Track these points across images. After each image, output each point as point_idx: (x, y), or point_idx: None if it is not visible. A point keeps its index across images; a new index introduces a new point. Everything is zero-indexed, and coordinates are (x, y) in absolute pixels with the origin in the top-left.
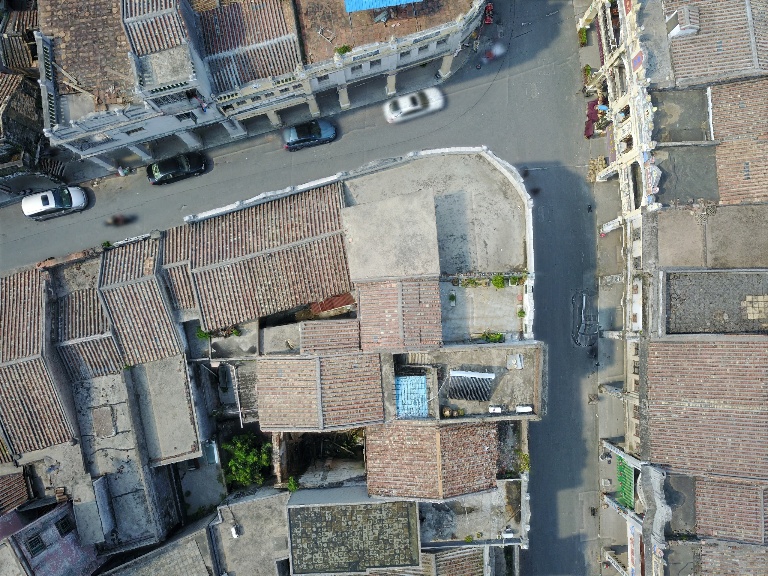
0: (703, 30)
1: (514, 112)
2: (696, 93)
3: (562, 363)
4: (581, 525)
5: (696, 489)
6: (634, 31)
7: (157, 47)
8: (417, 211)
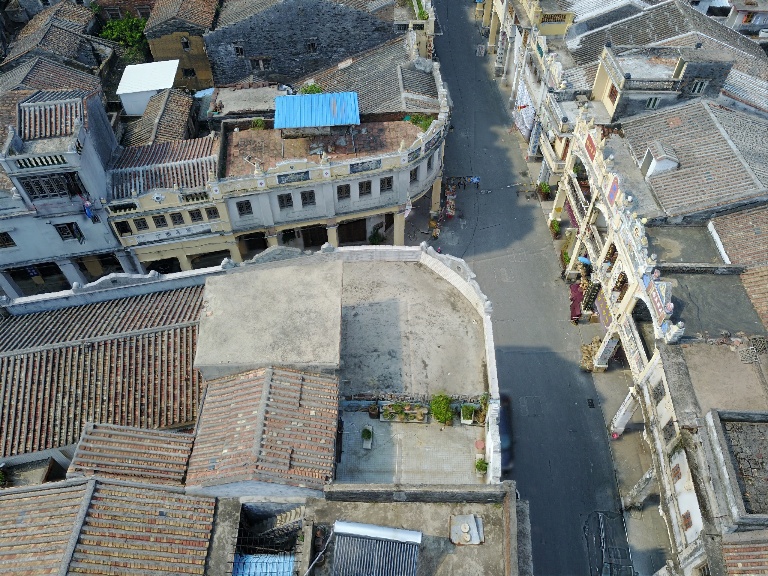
0: (684, 165)
1: None
2: (695, 230)
3: None
4: None
5: None
6: (603, 166)
7: (48, 133)
8: (315, 284)
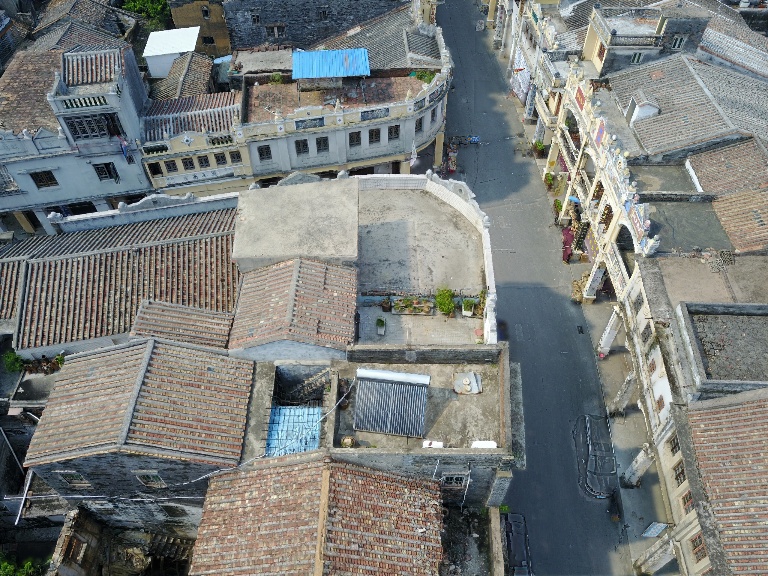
0: (664, 111)
1: None
2: (674, 168)
3: (569, 524)
4: None
5: None
6: (591, 113)
7: (90, 79)
8: (335, 196)
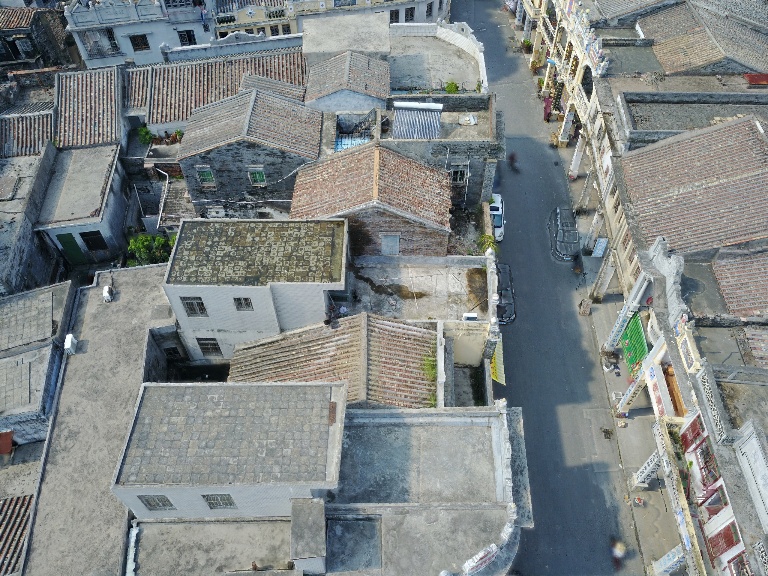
0: None
1: None
2: (627, 31)
3: (543, 276)
4: (592, 450)
5: (715, 274)
6: None
7: None
8: (372, 22)
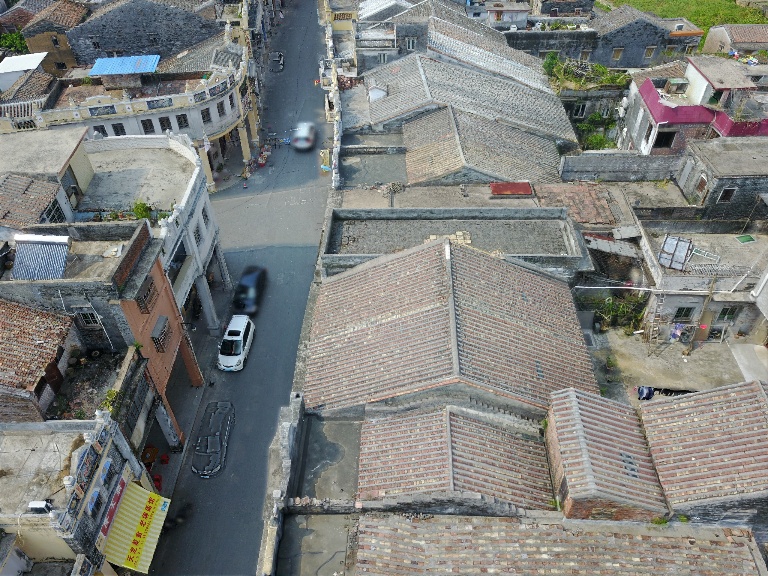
0: (391, 93)
1: (271, 212)
2: (394, 136)
3: (276, 413)
4: None
5: (361, 437)
6: None
7: None
8: (63, 138)
